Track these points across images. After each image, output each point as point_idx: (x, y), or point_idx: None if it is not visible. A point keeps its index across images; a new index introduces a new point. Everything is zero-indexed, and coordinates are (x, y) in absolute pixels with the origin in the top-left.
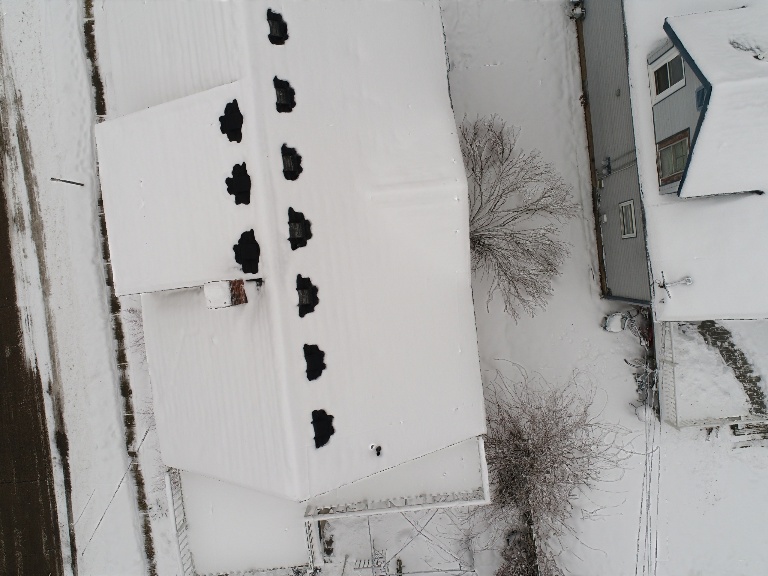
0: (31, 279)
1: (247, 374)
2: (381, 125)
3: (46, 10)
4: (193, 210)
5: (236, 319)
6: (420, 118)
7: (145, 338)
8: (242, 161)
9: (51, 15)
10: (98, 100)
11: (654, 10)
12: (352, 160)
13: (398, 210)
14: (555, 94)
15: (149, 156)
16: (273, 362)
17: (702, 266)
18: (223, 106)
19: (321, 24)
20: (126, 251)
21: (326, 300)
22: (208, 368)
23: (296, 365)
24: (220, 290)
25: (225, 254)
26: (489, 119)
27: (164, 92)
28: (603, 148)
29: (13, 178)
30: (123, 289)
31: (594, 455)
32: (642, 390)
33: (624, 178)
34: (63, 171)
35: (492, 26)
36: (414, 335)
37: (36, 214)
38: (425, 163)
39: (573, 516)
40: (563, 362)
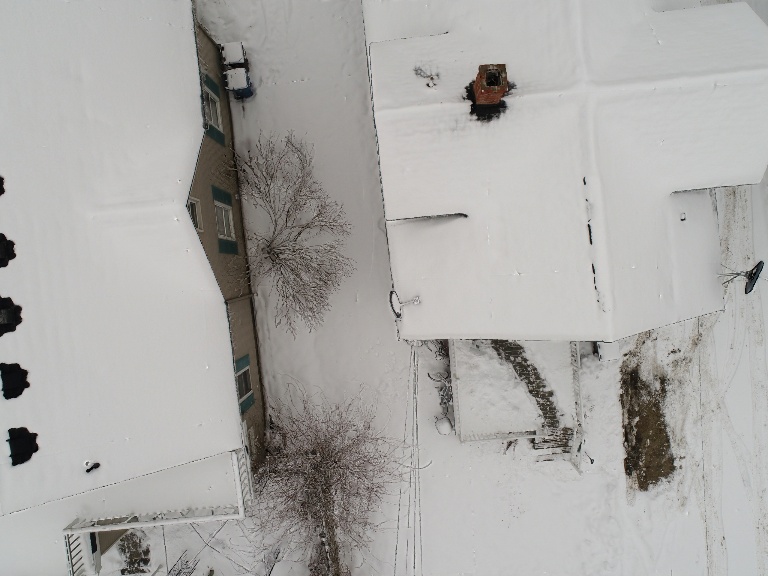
0: None
1: None
2: (110, 145)
3: None
4: None
5: None
6: (160, 138)
7: None
8: None
9: None
10: None
11: (384, 33)
12: (71, 181)
13: (124, 230)
14: (360, 110)
15: None
16: None
17: (427, 286)
18: None
19: (32, 47)
20: None
21: (31, 319)
22: None
23: None
24: None
25: None
26: (297, 134)
27: None
28: None
29: None
30: None
31: (378, 469)
32: (445, 404)
33: None
34: None
35: (300, 42)
36: (147, 352)
37: None
38: (153, 183)
39: None
40: (370, 375)
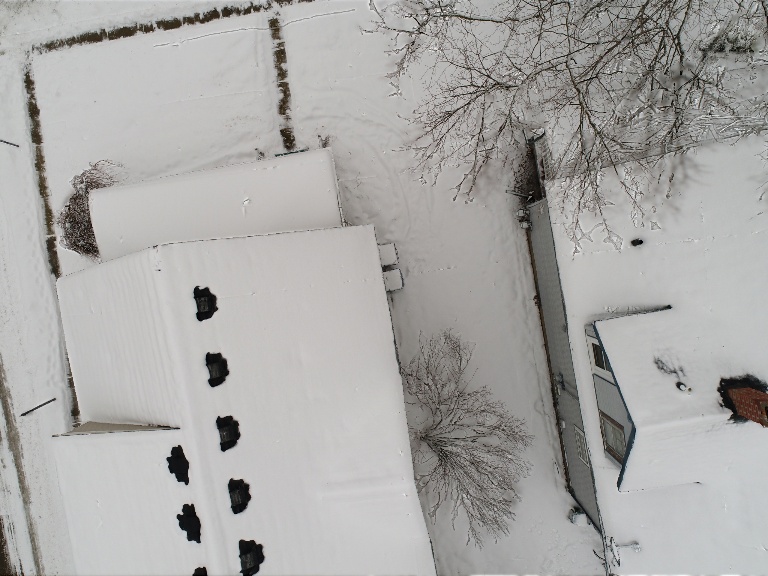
0: (11, 488)
1: None
2: (328, 420)
3: (8, 230)
4: (148, 538)
5: None
6: (368, 398)
7: None
8: (191, 503)
9: (13, 236)
10: None
11: (587, 287)
12: (301, 466)
13: (350, 503)
14: (509, 296)
15: (104, 480)
16: None
17: (649, 535)
18: (169, 449)
19: (261, 346)
20: (88, 563)
21: None
22: None
23: None
24: None
25: None
26: (446, 321)
27: (116, 401)
28: (557, 361)
29: None
30: None
31: None
32: None
33: (576, 407)
34: (35, 385)
35: (444, 231)
36: None
37: (12, 425)
38: (373, 454)
39: None
40: (534, 553)
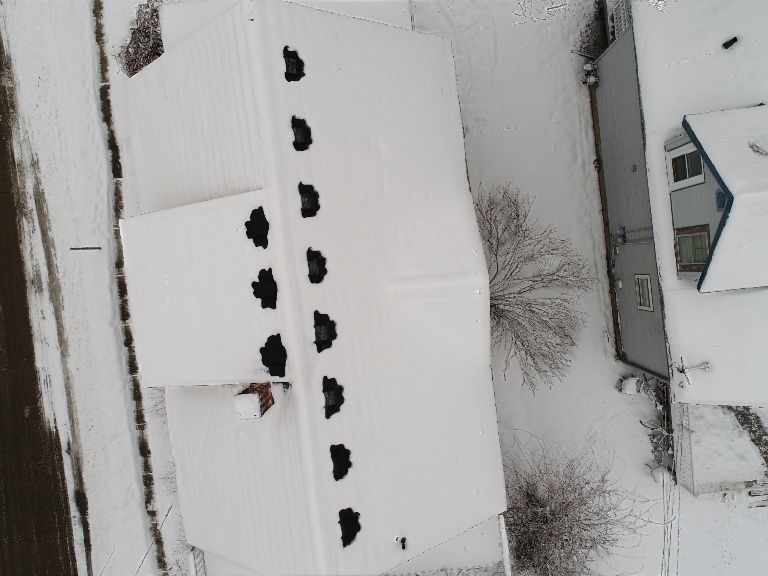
0: (49, 340)
1: (274, 472)
2: (402, 217)
3: (62, 75)
4: (219, 311)
5: (262, 417)
6: (440, 206)
7: (168, 419)
8: (268, 267)
9: (67, 81)
10: (114, 164)
11: (671, 99)
12: (375, 256)
13: (420, 302)
14: (569, 158)
15: (175, 255)
16: (301, 465)
17: (721, 353)
18: (249, 212)
19: (343, 124)
20: (152, 346)
21: (351, 398)
22: (234, 459)
23: (323, 467)
24: (250, 404)
25: (252, 356)
26: (503, 183)
27: (187, 186)
28: (618, 216)
29: (31, 240)
30: (149, 382)
31: (612, 522)
32: (658, 451)
33: (640, 252)
34: (80, 234)
35: (505, 91)
36: (436, 422)
37: (54, 276)
38: (446, 254)
39: (590, 575)
40: (579, 423)
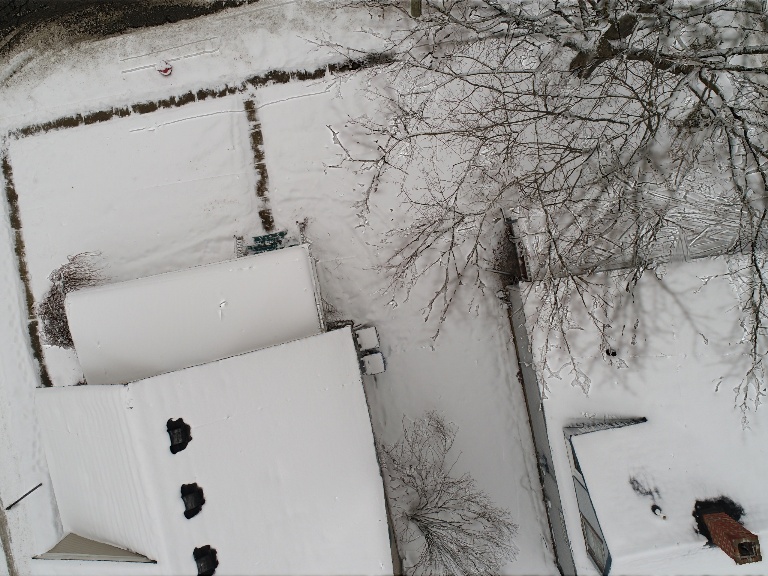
0: None
1: None
2: (309, 533)
3: None
4: None
5: None
6: (348, 505)
7: None
8: None
9: None
10: None
11: (564, 391)
12: None
13: None
14: (492, 373)
15: None
16: None
17: None
18: None
19: (238, 469)
20: None
21: None
22: None
23: None
24: None
25: None
26: (430, 399)
27: (95, 520)
28: (540, 443)
29: None
30: None
31: None
32: None
33: None
34: (21, 471)
35: None
36: None
37: None
38: (354, 567)
39: None
40: None
